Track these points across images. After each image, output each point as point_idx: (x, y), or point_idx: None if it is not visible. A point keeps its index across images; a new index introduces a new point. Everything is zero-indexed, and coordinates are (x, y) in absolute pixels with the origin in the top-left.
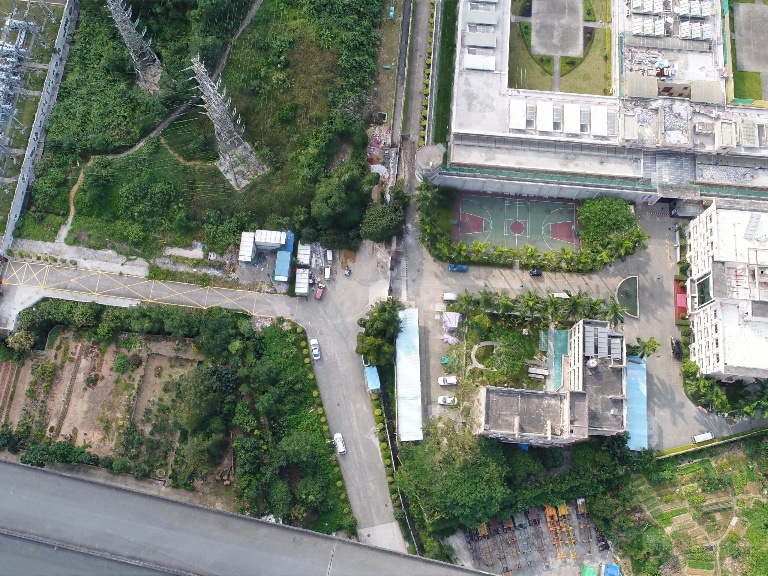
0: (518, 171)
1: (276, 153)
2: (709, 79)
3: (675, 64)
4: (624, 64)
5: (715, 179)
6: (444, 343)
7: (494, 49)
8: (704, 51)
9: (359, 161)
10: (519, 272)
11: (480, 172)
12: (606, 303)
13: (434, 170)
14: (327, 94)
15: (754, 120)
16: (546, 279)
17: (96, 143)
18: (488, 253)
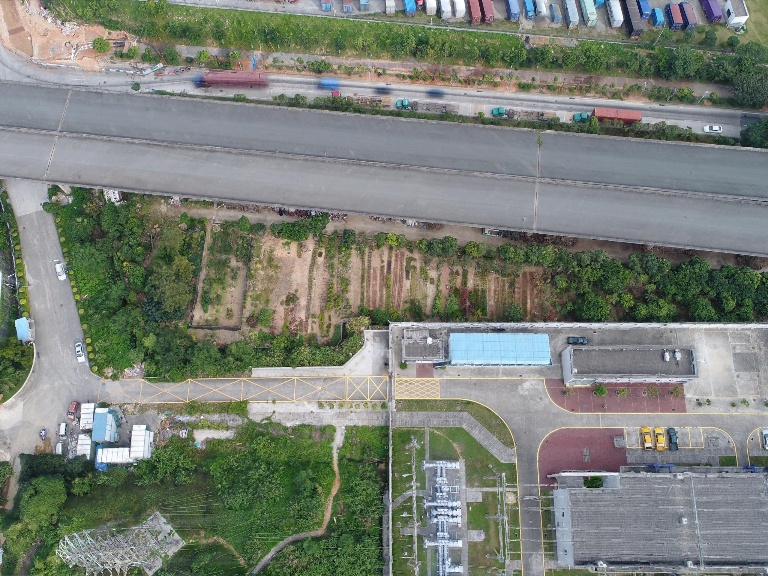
0: None
1: None
2: None
3: None
4: None
5: None
6: None
7: None
8: None
9: (9, 558)
10: None
11: None
12: None
13: None
14: None
15: None
16: None
17: (309, 541)
18: None
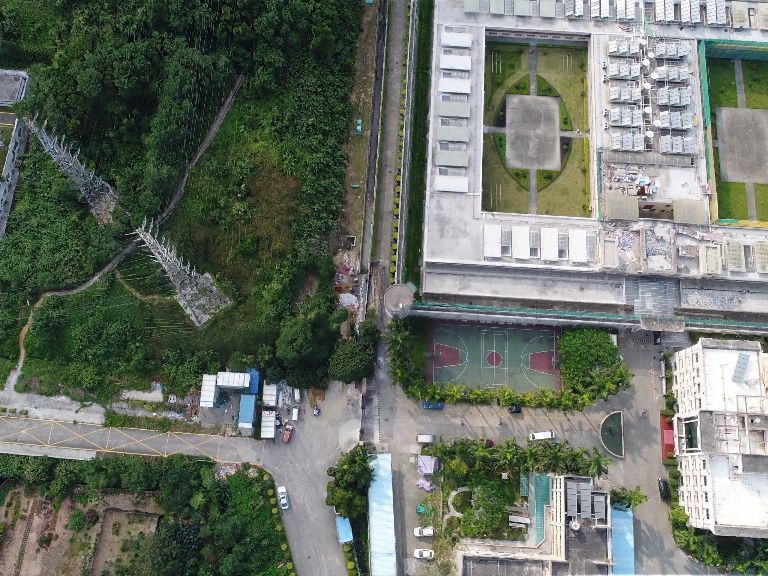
0: (494, 298)
1: (238, 286)
2: (692, 197)
3: (656, 181)
4: (603, 182)
5: (701, 305)
6: (419, 489)
7: (466, 168)
8: (686, 166)
9: (326, 294)
10: (497, 408)
11: (454, 300)
12: (589, 453)
13: (404, 310)
14: (291, 224)
15: (740, 241)
16: (526, 416)
17: (46, 283)
18: (464, 395)
